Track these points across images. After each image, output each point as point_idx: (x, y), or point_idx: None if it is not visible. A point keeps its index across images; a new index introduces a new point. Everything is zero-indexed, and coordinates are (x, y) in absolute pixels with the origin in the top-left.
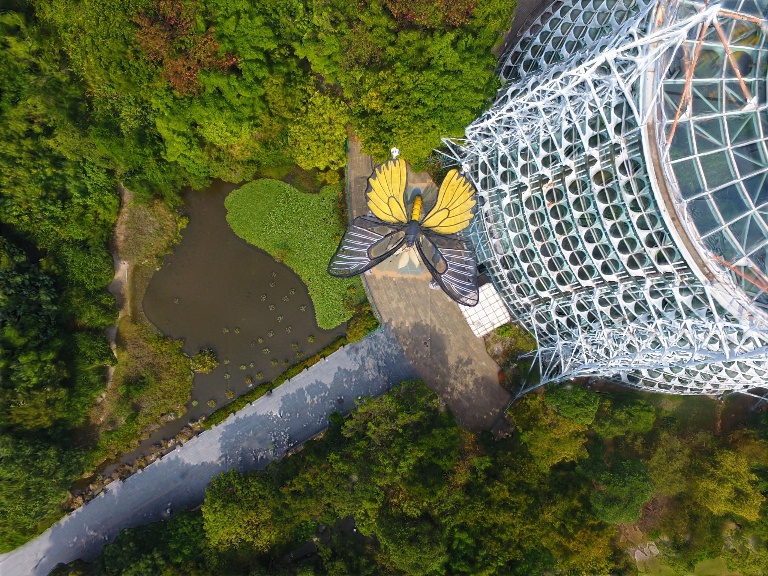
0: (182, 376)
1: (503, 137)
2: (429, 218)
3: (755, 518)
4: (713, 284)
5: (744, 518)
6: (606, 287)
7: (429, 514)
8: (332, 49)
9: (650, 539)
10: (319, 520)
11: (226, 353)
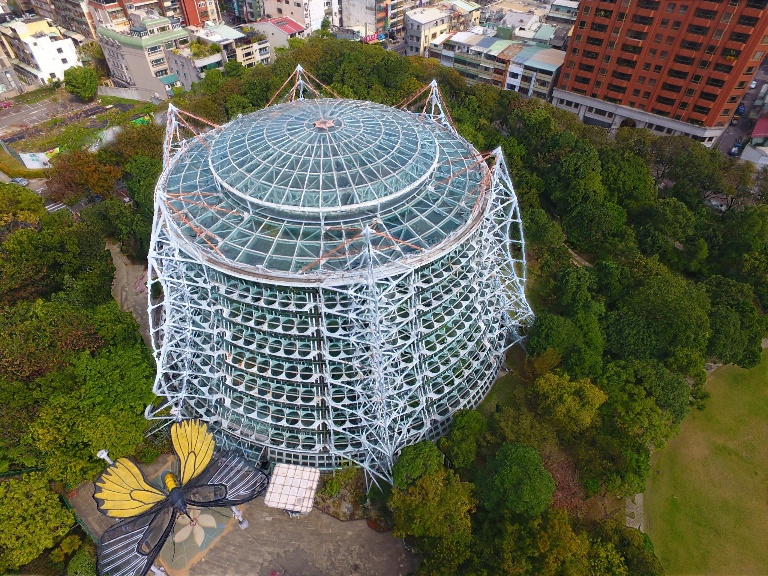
0: None
1: None
2: (183, 475)
3: (605, 395)
4: None
5: (607, 405)
6: (324, 366)
7: None
8: None
9: (598, 491)
10: None
11: None
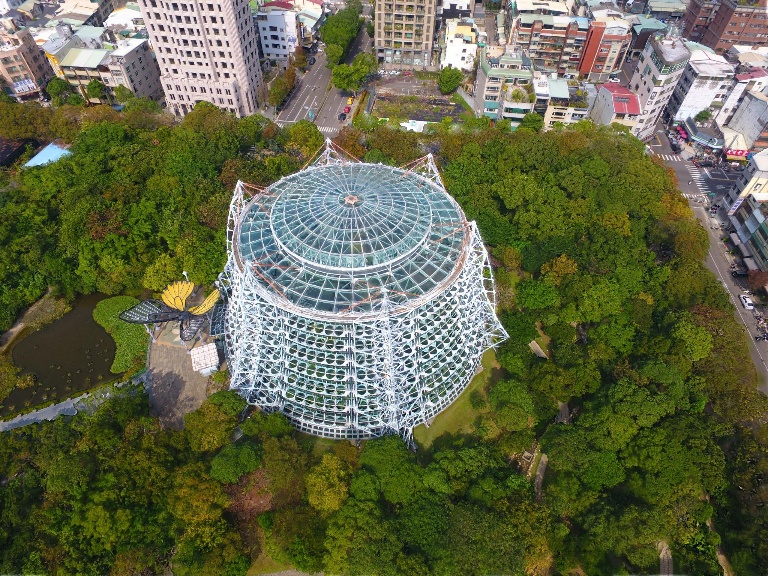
0: (6, 388)
1: None
2: (196, 310)
3: (338, 507)
4: (243, 273)
5: None
6: None
7: (95, 456)
8: (175, 234)
9: (259, 524)
10: (24, 483)
11: (44, 380)
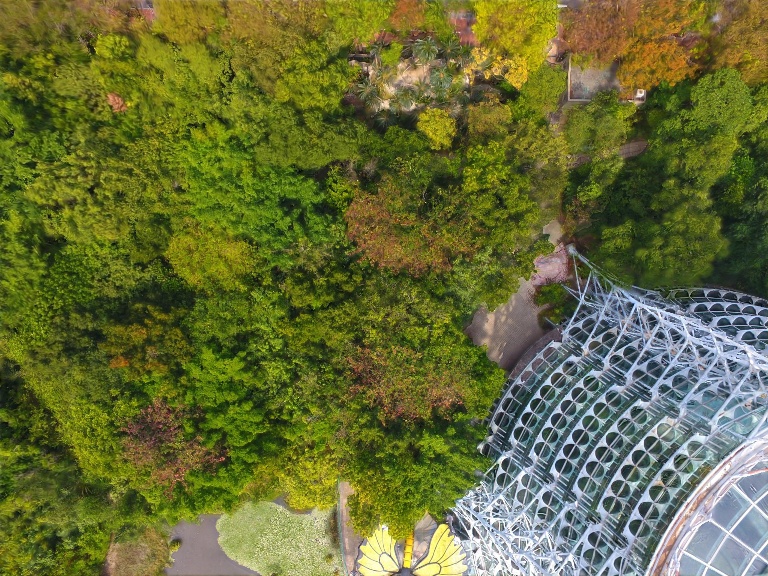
0: None
1: (494, 507)
2: (421, 567)
3: None
4: None
5: None
6: None
7: None
8: (321, 433)
9: None
10: None
11: None
